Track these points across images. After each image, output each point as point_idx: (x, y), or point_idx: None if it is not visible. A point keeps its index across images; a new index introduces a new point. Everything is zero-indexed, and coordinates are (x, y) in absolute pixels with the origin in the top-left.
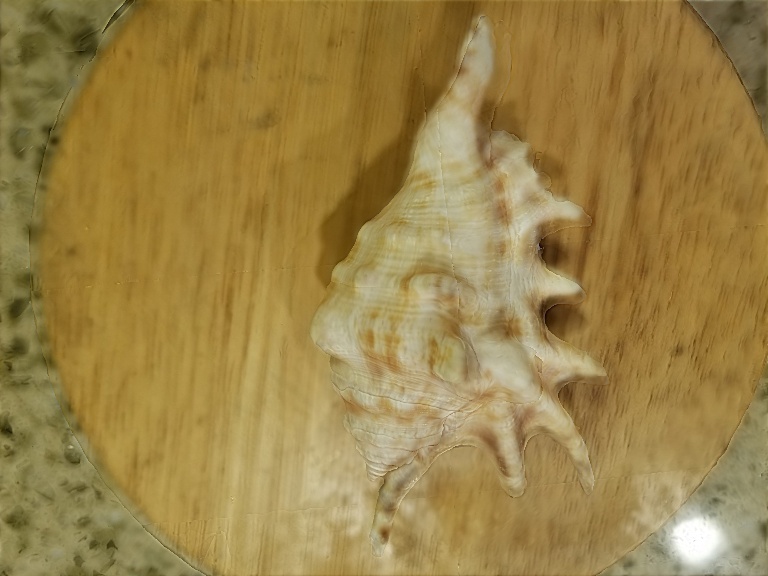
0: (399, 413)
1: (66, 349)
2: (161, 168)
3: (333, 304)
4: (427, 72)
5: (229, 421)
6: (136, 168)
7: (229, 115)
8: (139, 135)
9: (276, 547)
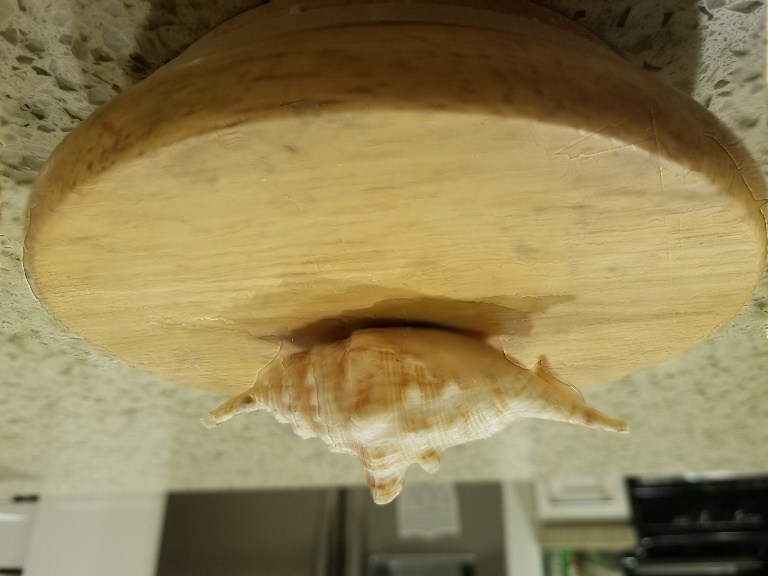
0: (327, 448)
1: (167, 174)
2: (447, 208)
3: (388, 421)
4: (587, 311)
5: (202, 279)
6: (439, 189)
7: (524, 235)
8: (481, 187)
9: (113, 313)
